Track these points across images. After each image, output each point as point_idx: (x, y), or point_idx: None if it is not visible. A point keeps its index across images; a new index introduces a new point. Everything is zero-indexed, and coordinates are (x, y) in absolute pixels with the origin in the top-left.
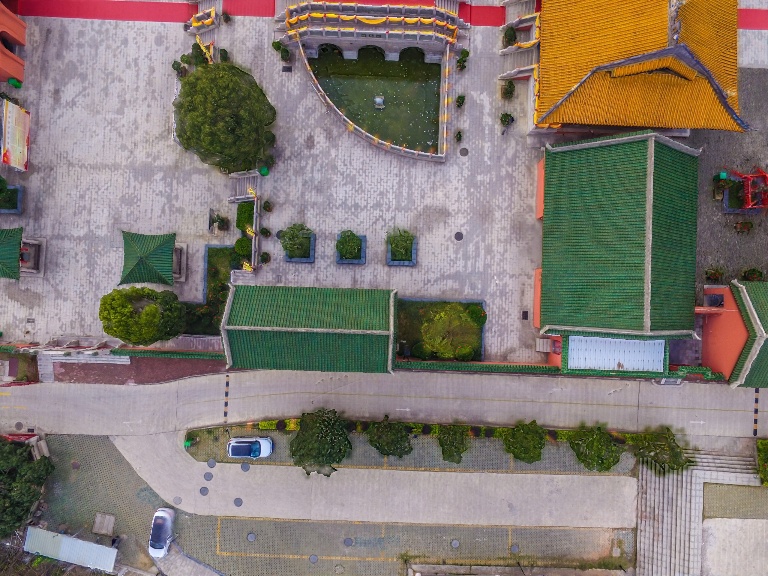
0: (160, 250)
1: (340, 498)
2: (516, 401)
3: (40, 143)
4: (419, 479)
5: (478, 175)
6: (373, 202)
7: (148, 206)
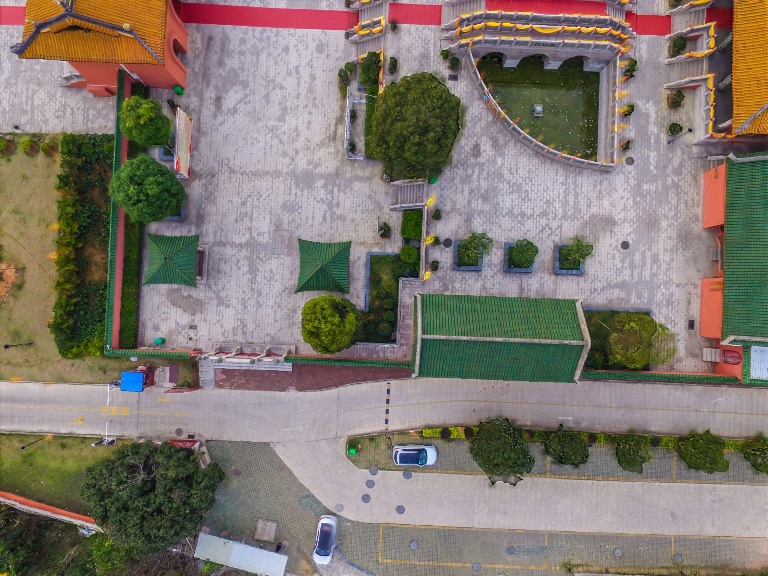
0: (337, 258)
1: (503, 506)
2: (680, 410)
3: (202, 150)
4: (582, 488)
5: (644, 184)
6: (539, 211)
7: (309, 213)
